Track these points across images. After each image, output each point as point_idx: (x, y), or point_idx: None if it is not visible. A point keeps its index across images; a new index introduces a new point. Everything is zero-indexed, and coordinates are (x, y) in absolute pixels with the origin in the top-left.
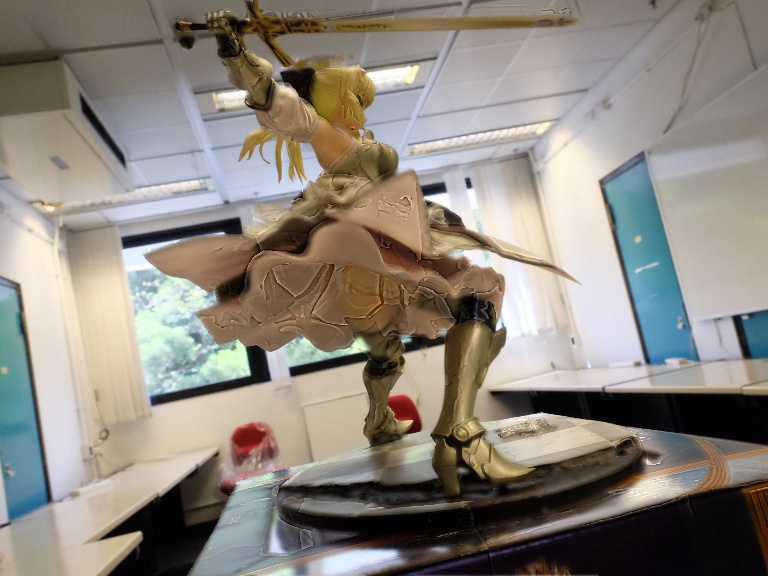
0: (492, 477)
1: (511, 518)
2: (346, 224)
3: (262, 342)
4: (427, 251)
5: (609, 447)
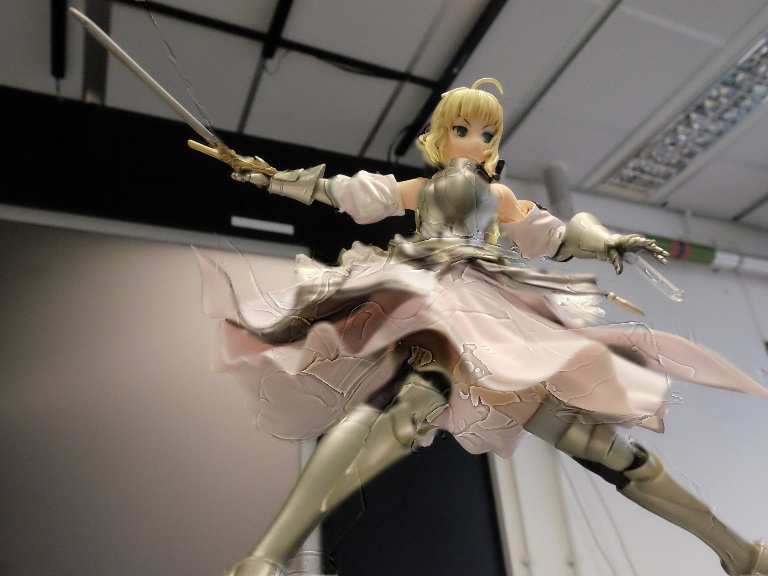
0: None
1: None
2: (233, 316)
3: (491, 453)
4: (284, 314)
5: None
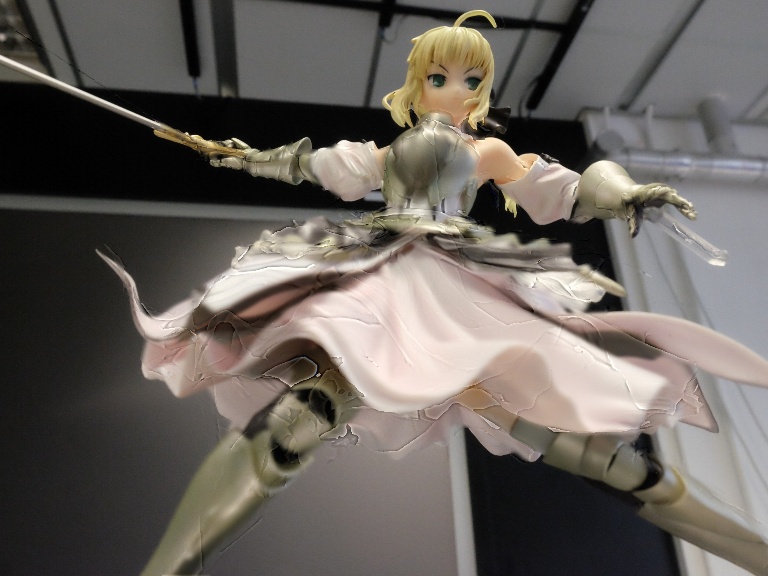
0: None
1: None
2: None
3: (510, 456)
4: None
5: None
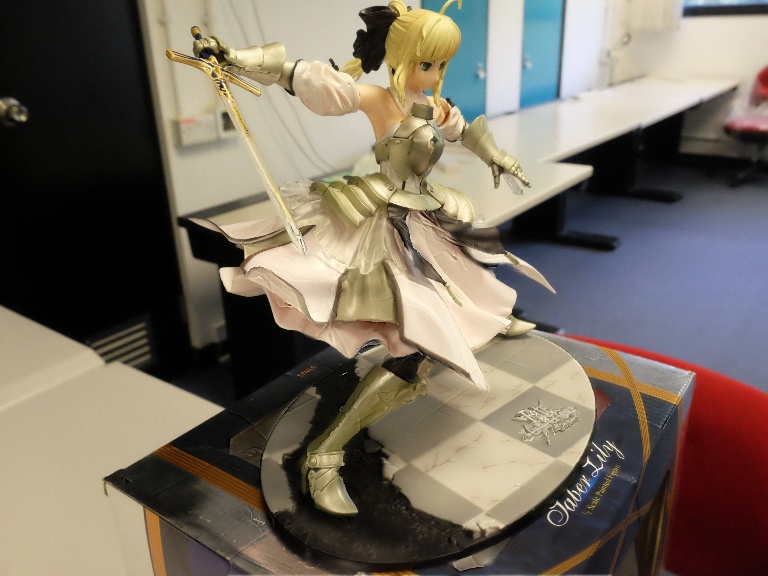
0: (316, 502)
1: (290, 541)
2: None
3: None
4: None
5: (457, 524)
